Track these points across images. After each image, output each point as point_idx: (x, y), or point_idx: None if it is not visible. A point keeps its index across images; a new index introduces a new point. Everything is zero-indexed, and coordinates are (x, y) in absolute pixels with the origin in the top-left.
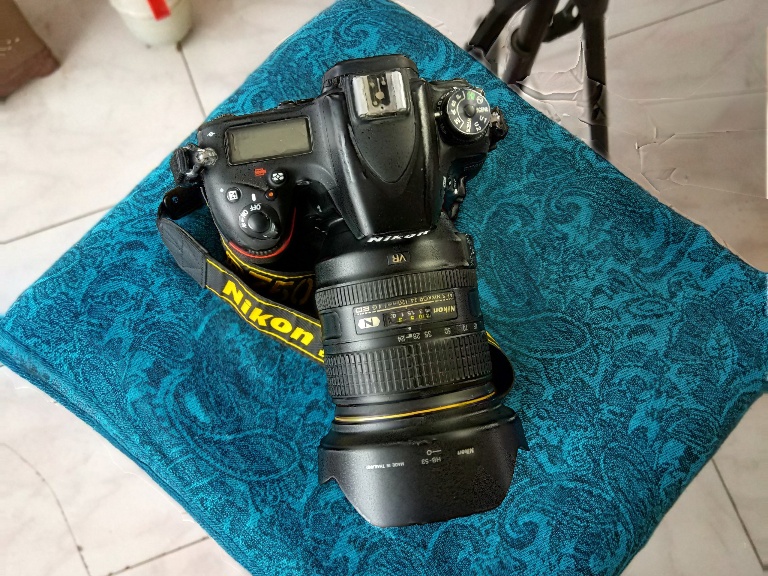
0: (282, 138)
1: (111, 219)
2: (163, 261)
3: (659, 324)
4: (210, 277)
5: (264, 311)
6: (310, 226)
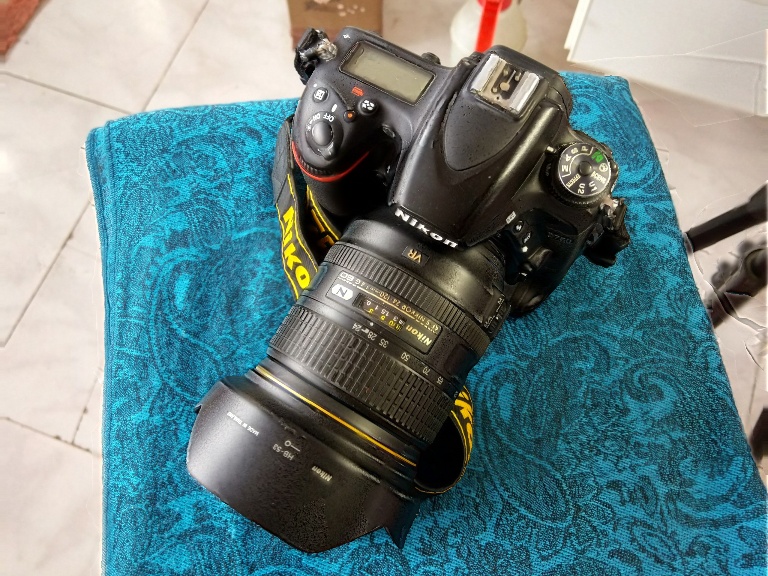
0: (400, 78)
1: (257, 104)
2: (264, 161)
3: (653, 568)
4: (283, 195)
5: (297, 251)
6: (382, 196)
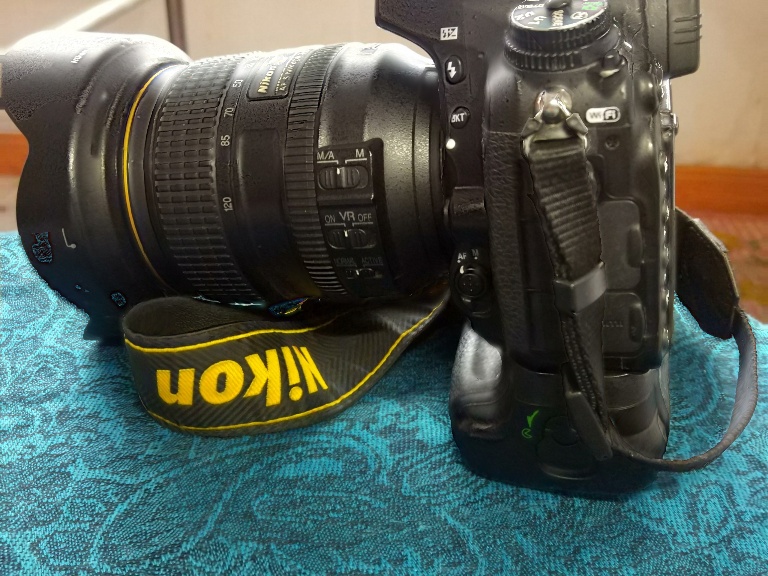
0: None
1: None
2: None
3: None
4: None
5: None
6: None
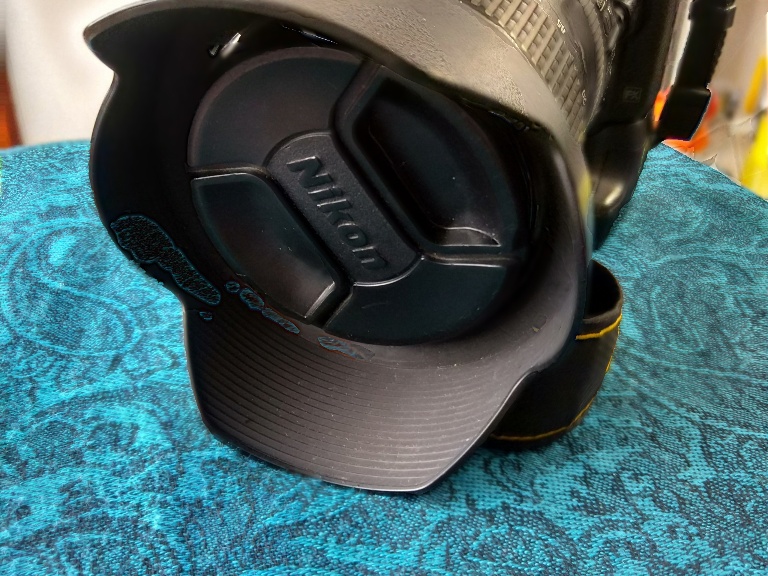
0: None
1: None
2: None
3: None
4: None
5: None
6: None
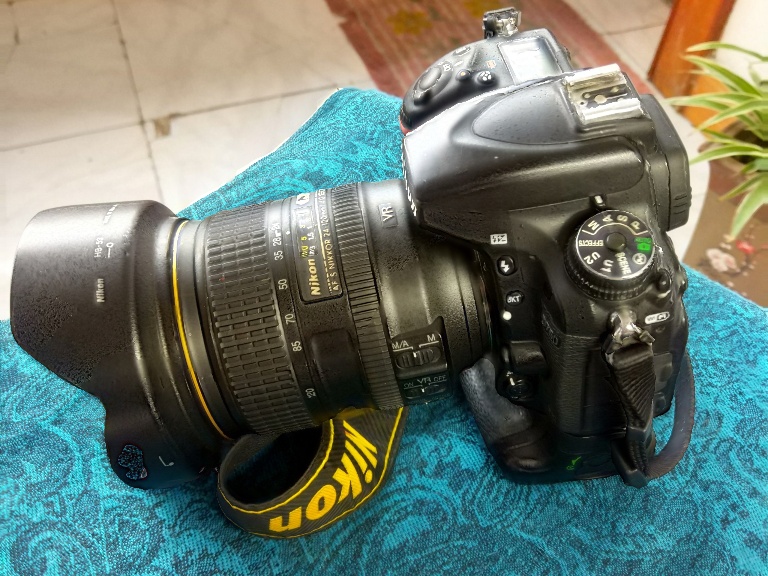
0: None
1: None
2: None
3: None
4: None
5: None
6: None
